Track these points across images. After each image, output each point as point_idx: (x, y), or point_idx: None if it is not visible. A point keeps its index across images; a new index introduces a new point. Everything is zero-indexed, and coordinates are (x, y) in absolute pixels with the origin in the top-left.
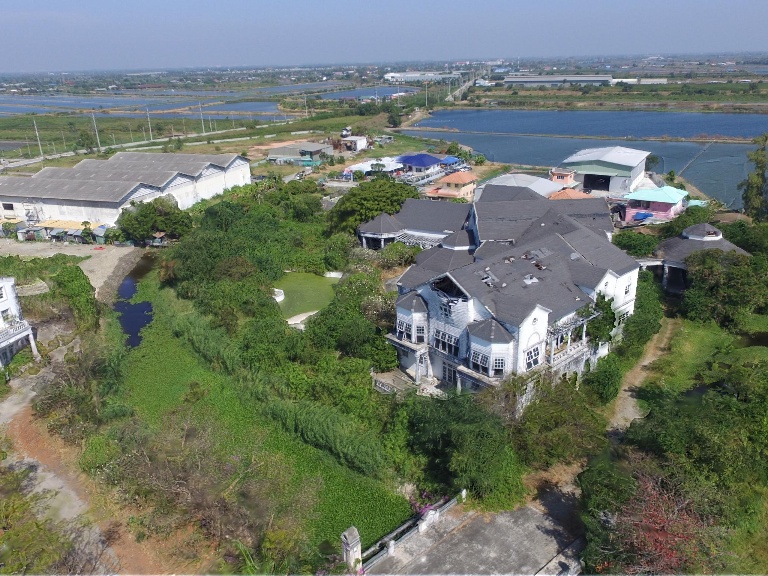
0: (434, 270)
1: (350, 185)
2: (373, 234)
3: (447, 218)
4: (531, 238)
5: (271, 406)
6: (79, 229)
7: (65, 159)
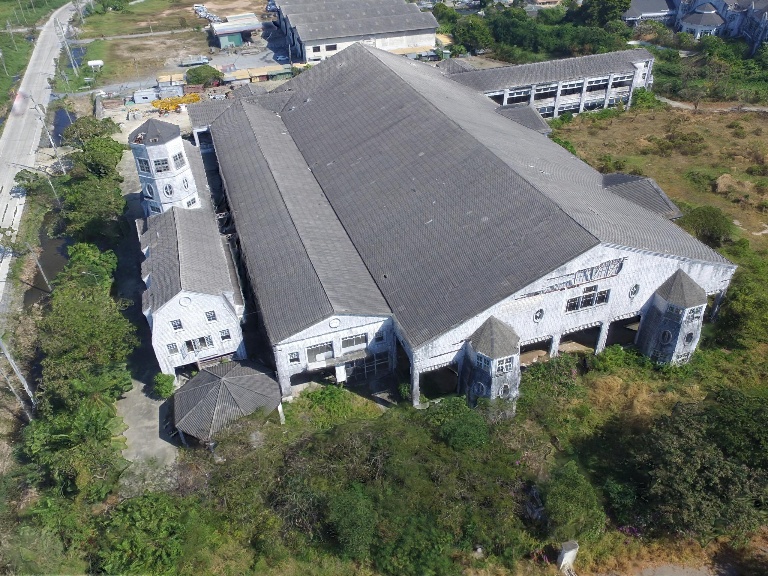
0: (711, 24)
1: (452, 5)
2: (634, 18)
3: (657, 3)
4: (747, 1)
5: (759, 76)
6: (427, 51)
7: (102, 20)
